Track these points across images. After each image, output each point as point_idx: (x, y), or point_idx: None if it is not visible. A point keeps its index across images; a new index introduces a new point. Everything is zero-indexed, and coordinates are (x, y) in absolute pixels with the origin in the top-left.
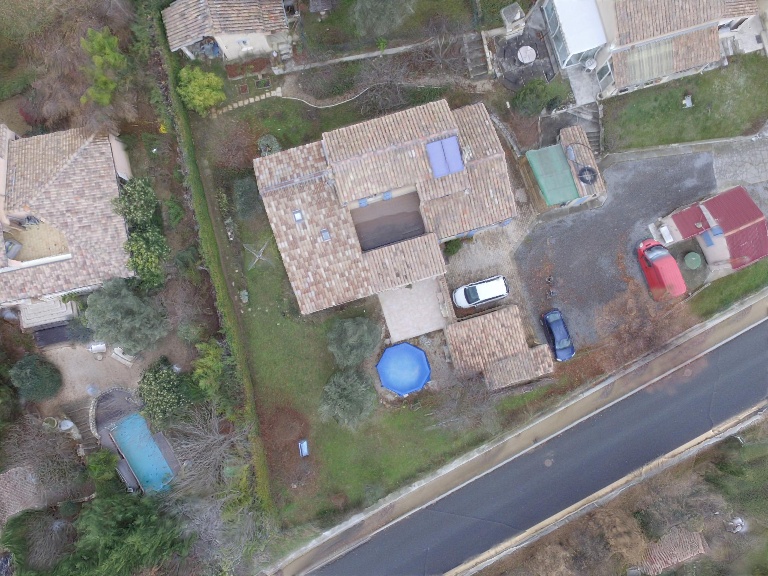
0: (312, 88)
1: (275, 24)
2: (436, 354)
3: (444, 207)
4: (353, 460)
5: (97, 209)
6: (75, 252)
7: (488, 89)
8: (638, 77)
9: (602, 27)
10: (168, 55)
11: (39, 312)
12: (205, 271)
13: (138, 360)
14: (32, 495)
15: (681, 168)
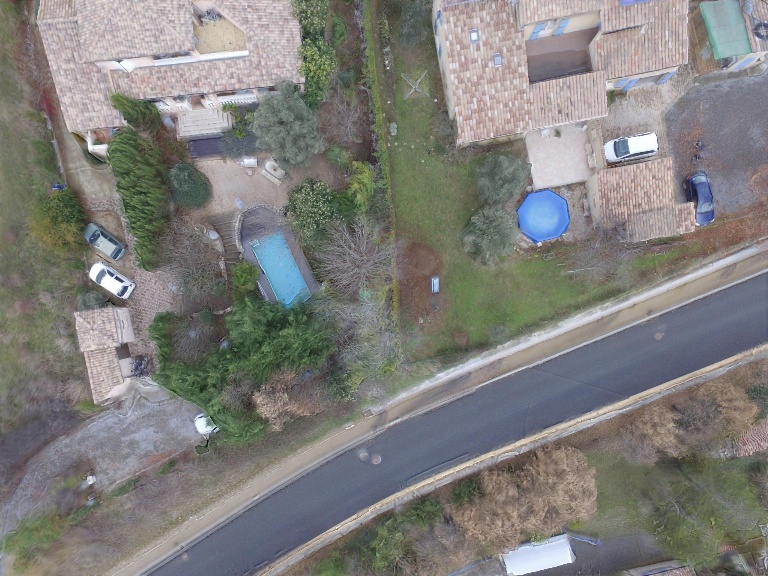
0: None
1: None
2: (574, 207)
3: (617, 45)
4: (480, 302)
5: (276, 9)
6: (252, 50)
7: None
8: None
9: None
10: None
11: (197, 120)
12: (365, 92)
13: (286, 180)
14: (169, 305)
15: None
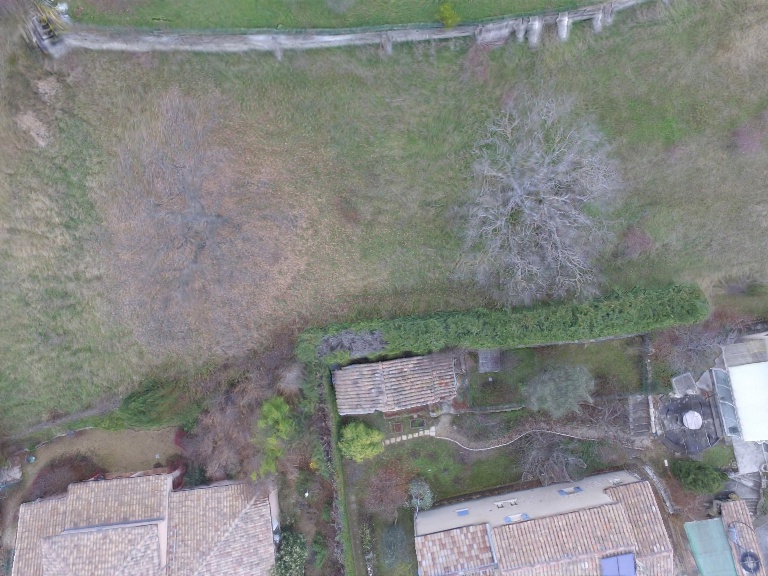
0: (467, 431)
1: (445, 390)
2: None
3: None
4: None
5: None
6: None
7: (647, 445)
8: None
9: None
10: (333, 411)
11: None
12: None
13: None
14: None
15: None
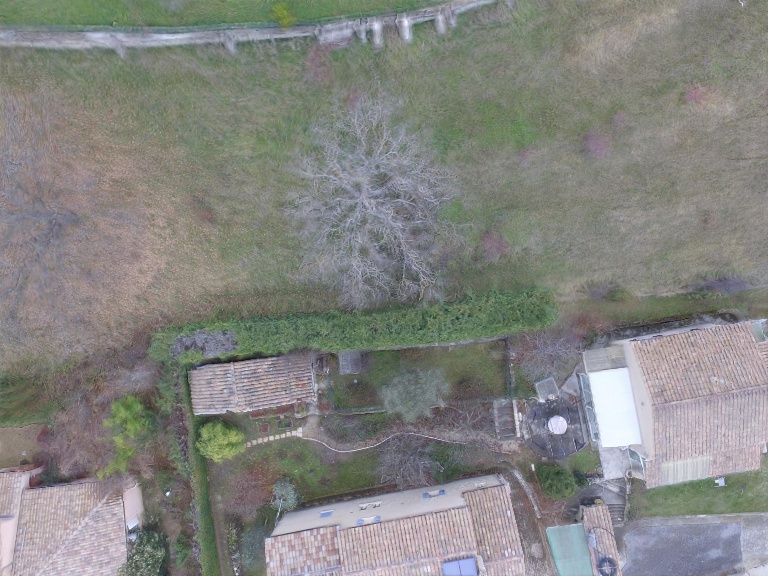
0: (334, 433)
1: (302, 391)
2: None
3: None
4: None
5: (103, 575)
6: None
7: (514, 449)
8: (671, 479)
9: (638, 428)
10: (190, 411)
11: None
12: None
13: None
14: None
15: (707, 538)
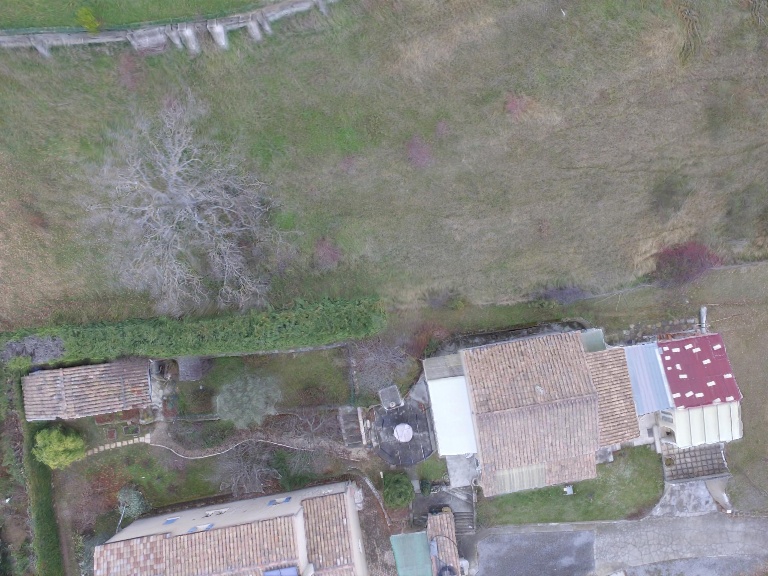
0: (181, 439)
1: (137, 398)
2: None
3: None
4: None
5: None
6: None
7: (363, 457)
8: (508, 488)
9: (474, 437)
10: None
11: None
12: None
13: None
14: None
15: (560, 546)
